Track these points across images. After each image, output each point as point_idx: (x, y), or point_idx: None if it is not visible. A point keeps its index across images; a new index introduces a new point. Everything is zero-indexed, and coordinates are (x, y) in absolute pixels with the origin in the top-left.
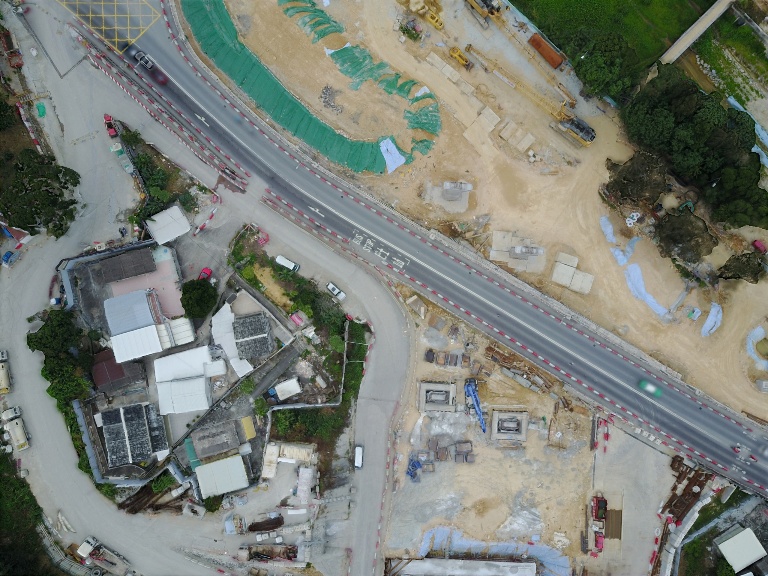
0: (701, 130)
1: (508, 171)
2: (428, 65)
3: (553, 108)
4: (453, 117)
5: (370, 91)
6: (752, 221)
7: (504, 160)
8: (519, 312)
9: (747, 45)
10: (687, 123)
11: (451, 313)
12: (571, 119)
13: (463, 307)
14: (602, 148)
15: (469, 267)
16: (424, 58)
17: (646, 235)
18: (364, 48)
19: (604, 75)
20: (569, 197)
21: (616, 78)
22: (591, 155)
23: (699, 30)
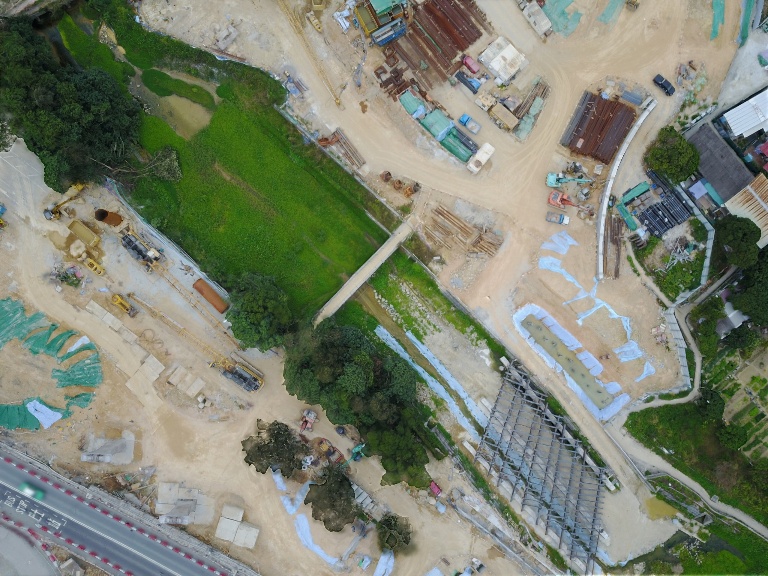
0: (340, 398)
1: (173, 421)
2: (88, 314)
3: (217, 357)
4: (115, 366)
5: (13, 352)
6: (404, 479)
7: (169, 410)
8: (183, 569)
9: (423, 280)
10: (334, 385)
11: (110, 575)
12: (235, 368)
13: (123, 567)
14: (276, 390)
15: (129, 526)
16: (84, 306)
17: (321, 477)
18: (17, 300)
19: (251, 336)
20: (240, 443)
21: (267, 336)
22: (264, 397)
23: (370, 270)
